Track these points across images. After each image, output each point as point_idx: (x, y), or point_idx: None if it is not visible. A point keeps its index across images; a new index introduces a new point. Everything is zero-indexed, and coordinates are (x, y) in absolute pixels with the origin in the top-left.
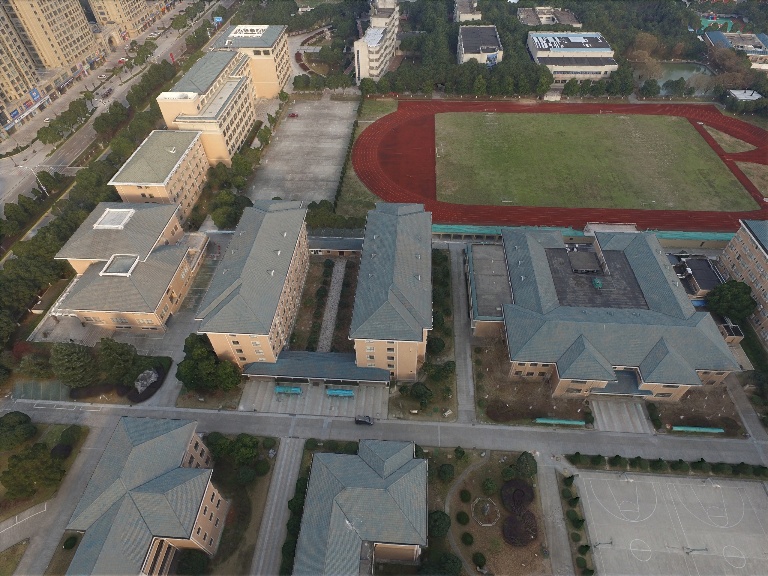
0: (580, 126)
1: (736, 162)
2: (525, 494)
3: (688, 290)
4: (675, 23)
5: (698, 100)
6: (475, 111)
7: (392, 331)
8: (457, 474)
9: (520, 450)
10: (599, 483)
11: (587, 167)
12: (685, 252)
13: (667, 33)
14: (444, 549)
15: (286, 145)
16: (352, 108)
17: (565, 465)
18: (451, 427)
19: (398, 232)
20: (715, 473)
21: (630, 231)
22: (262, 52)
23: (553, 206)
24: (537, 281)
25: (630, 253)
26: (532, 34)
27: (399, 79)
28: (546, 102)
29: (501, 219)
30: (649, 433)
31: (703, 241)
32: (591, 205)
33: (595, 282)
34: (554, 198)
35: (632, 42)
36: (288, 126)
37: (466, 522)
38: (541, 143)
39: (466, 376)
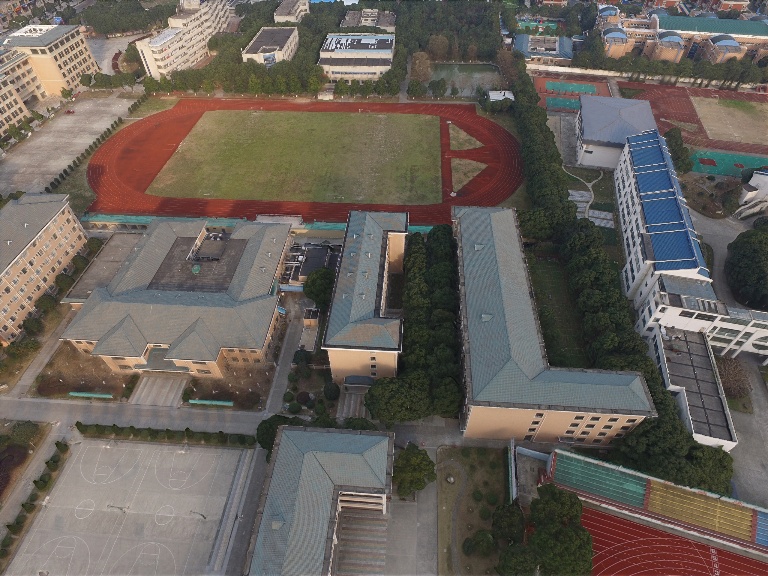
0: (333, 124)
1: (452, 159)
2: (13, 459)
3: (297, 277)
4: (489, 26)
5: (464, 100)
6: (245, 109)
7: None
8: None
9: (45, 421)
10: (93, 450)
11: (309, 163)
12: (326, 242)
13: None
14: None
15: (42, 140)
16: None
17: (75, 434)
18: None
19: None
20: (206, 442)
21: (292, 222)
22: (39, 51)
23: (249, 199)
24: (132, 266)
25: (250, 242)
26: (331, 35)
27: (178, 78)
28: (319, 101)
29: (190, 211)
30: (174, 406)
31: None
32: (285, 198)
33: (192, 268)
34: (255, 191)
35: (426, 44)
36: (57, 122)
37: None
38: (283, 140)
39: (47, 354)
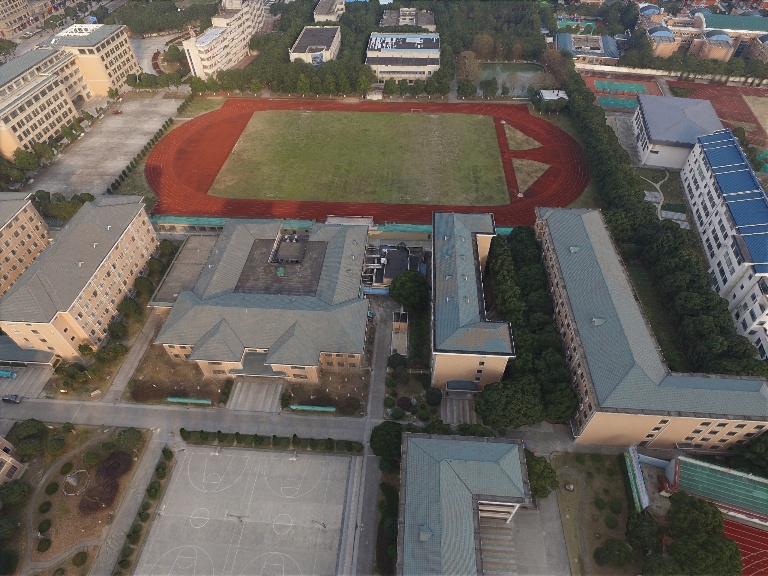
0: (386, 124)
1: (513, 159)
2: (119, 467)
3: (380, 279)
4: (530, 25)
5: (514, 100)
6: (295, 109)
7: (23, 313)
8: (71, 448)
9: (144, 427)
10: (199, 457)
11: (368, 163)
12: (402, 244)
13: (519, 35)
14: (18, 516)
15: (94, 141)
16: (178, 106)
17: (177, 441)
18: (92, 406)
19: (82, 222)
20: (312, 448)
21: (364, 224)
22: (87, 51)
23: (314, 200)
24: (218, 269)
25: (330, 244)
26: (374, 35)
27: (225, 78)
28: (368, 101)
29: (256, 212)
30: (273, 412)
31: (429, 234)
32: (350, 199)
33: None
34: (319, 193)
35: (471, 43)
36: (107, 123)
37: (52, 492)
38: (339, 140)
39: (135, 359)
